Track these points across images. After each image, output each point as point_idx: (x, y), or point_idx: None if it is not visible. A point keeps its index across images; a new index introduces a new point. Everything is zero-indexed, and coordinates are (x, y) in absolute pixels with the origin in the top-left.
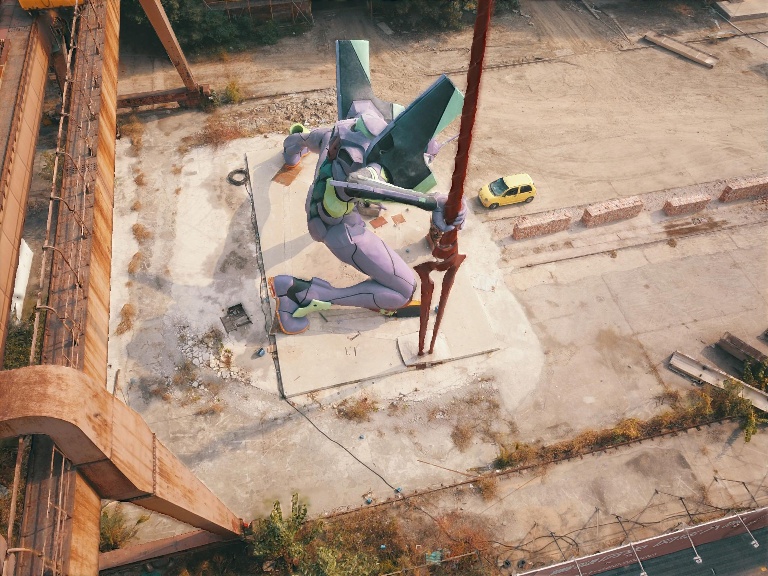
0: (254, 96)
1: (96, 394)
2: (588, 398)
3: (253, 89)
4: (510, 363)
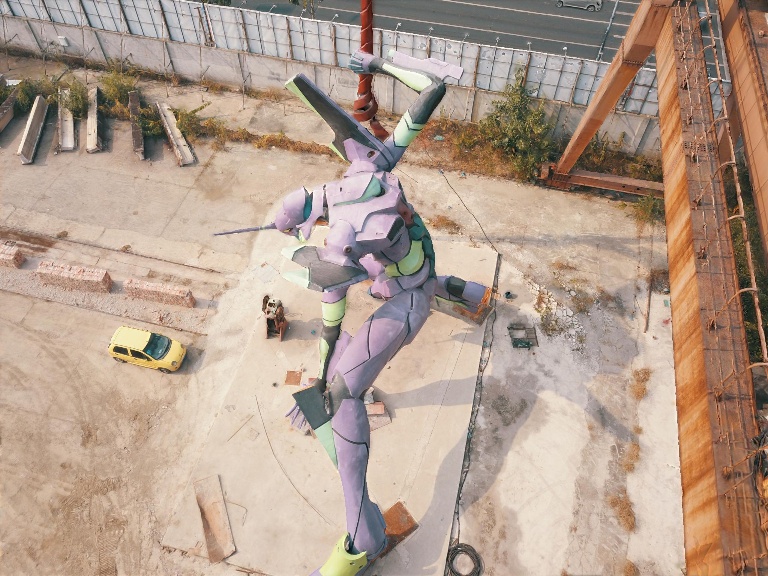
0: None
1: None
2: (272, 168)
3: None
4: None
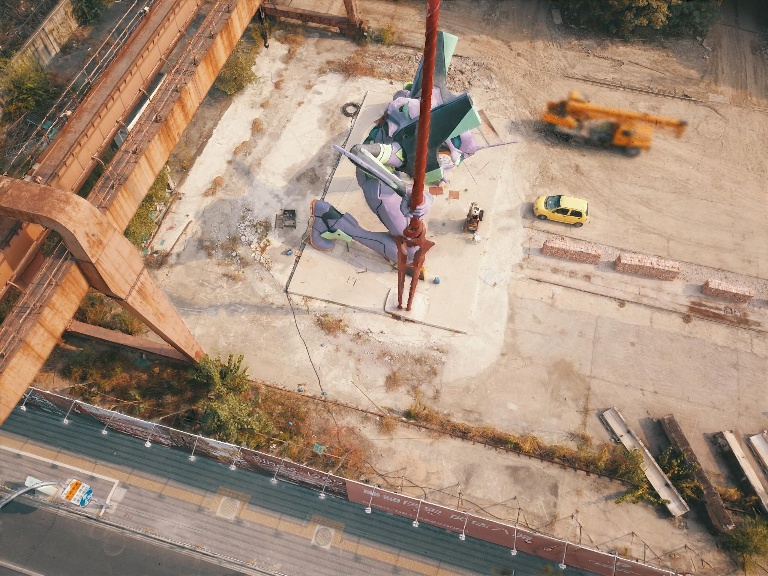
0: (404, 43)
1: (101, 223)
2: (512, 405)
3: (407, 37)
4: (468, 348)
